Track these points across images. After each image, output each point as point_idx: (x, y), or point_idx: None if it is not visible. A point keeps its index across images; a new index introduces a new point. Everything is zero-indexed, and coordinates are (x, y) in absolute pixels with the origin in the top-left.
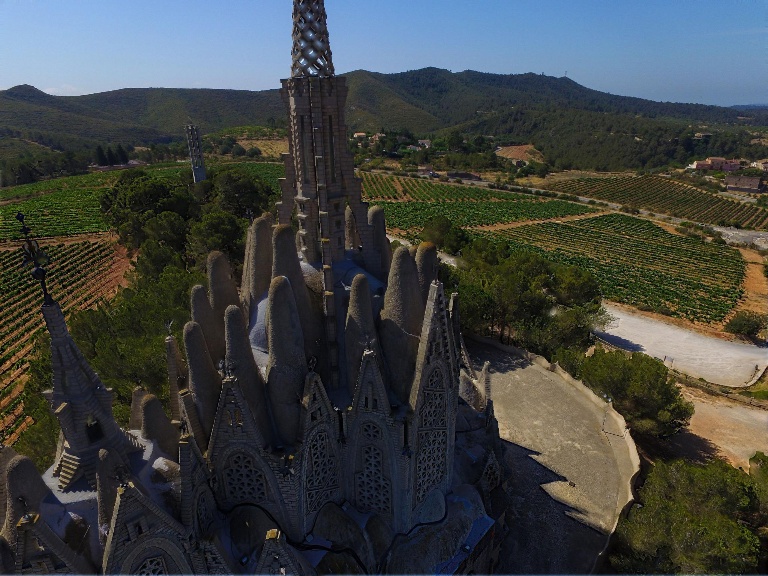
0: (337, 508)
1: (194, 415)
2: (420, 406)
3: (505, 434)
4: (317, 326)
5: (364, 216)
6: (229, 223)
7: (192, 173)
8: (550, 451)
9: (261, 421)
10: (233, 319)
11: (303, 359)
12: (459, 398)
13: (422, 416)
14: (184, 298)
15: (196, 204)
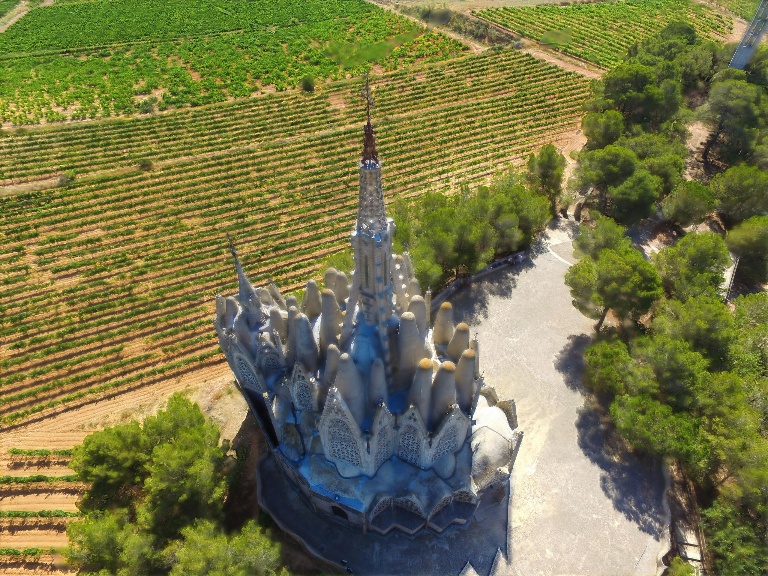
0: (313, 416)
1: (286, 329)
2: (330, 425)
3: (515, 522)
4: (337, 344)
5: (380, 317)
6: (623, 164)
7: (736, 50)
8: (514, 569)
9: (292, 356)
10: (289, 313)
11: (306, 353)
12: (471, 461)
13: (330, 429)
14: (469, 229)
15: (675, 104)
